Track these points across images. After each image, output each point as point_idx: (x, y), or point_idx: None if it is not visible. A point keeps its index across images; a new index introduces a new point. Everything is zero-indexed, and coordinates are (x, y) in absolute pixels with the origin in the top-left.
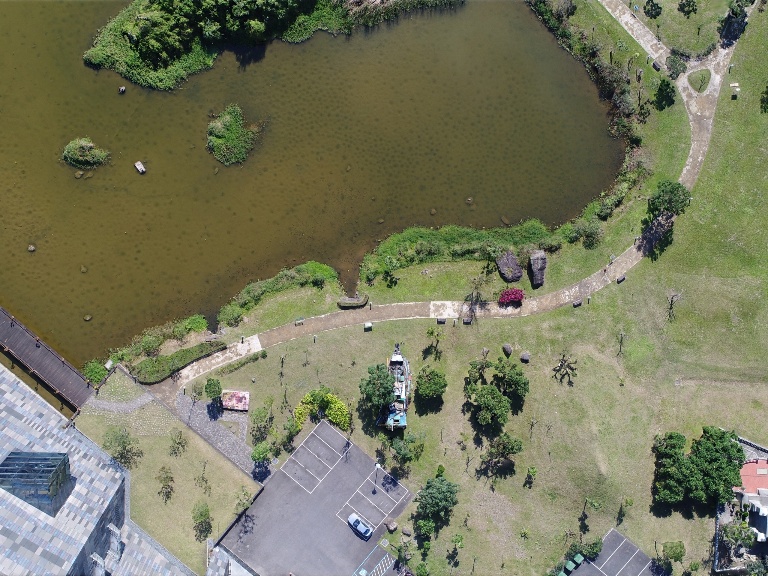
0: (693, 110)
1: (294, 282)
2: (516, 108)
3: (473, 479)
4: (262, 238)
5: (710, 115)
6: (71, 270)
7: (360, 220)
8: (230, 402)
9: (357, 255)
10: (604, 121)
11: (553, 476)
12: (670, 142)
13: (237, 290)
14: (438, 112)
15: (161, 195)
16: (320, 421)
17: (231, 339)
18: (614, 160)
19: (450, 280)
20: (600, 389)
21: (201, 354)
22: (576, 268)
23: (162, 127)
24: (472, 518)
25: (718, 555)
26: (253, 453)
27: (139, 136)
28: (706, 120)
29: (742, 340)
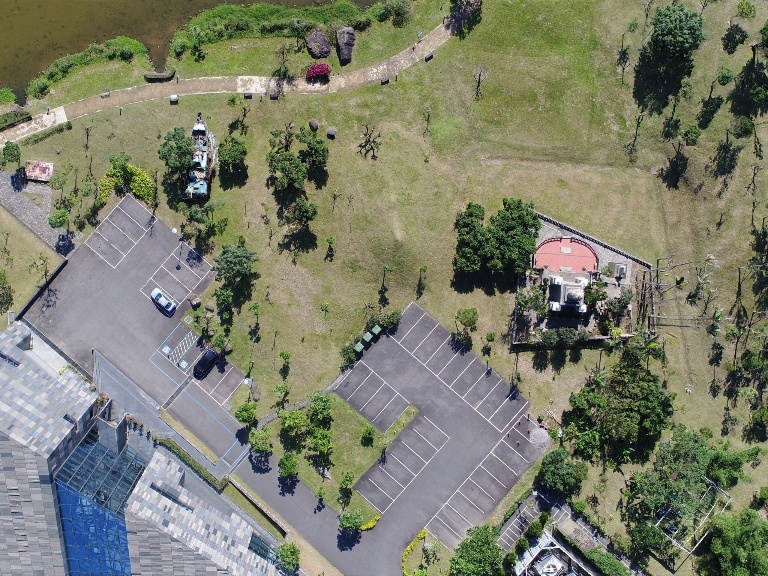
0: None
1: (102, 55)
2: None
3: (275, 253)
4: (73, 13)
5: None
6: None
7: None
8: (33, 172)
9: (167, 31)
10: None
11: (353, 247)
12: None
13: (46, 64)
14: None
15: None
16: (125, 195)
17: (37, 110)
18: None
19: (258, 55)
20: (403, 163)
21: (5, 123)
22: (384, 46)
23: None
24: (274, 292)
25: (516, 328)
26: (50, 217)
27: None
28: None
29: (548, 119)
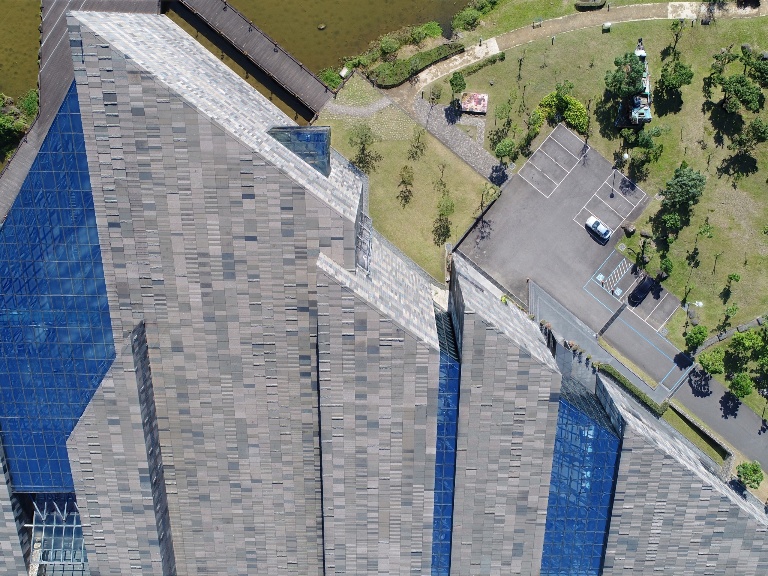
0: None
1: None
2: None
3: (714, 177)
4: None
5: None
6: None
7: None
8: (469, 104)
9: None
10: None
11: None
12: None
13: None
14: None
15: None
16: (557, 125)
17: (469, 42)
18: None
19: None
20: None
21: (440, 56)
22: None
23: None
24: (713, 217)
25: None
26: (499, 146)
27: None
28: None
29: None
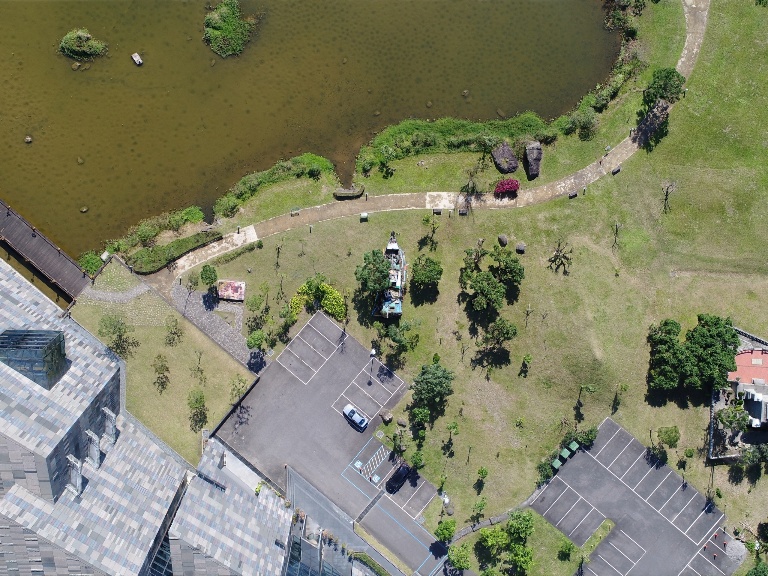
0: (688, 2)
1: (290, 173)
2: (512, 1)
3: (468, 369)
4: (258, 130)
5: (705, 7)
6: (68, 162)
7: (356, 112)
8: (226, 292)
9: (353, 147)
10: (600, 14)
11: (548, 364)
12: (665, 34)
13: (233, 182)
14: (434, 5)
15: (158, 87)
16: (316, 312)
17: (227, 229)
18: (609, 53)
19: (446, 171)
20: (595, 278)
21: (197, 244)
22: (571, 159)
23: (159, 19)
24: (467, 408)
25: (713, 442)
26: (248, 339)
27: (136, 28)
28: (701, 12)
29: (737, 231)
